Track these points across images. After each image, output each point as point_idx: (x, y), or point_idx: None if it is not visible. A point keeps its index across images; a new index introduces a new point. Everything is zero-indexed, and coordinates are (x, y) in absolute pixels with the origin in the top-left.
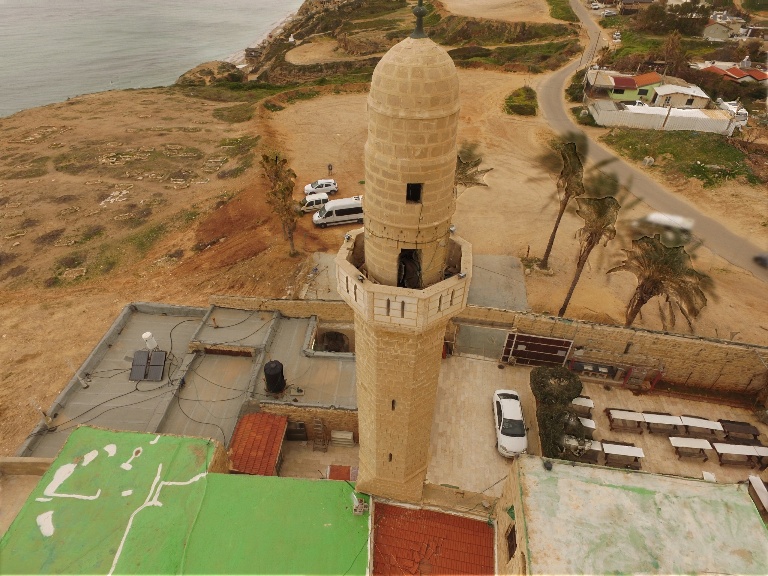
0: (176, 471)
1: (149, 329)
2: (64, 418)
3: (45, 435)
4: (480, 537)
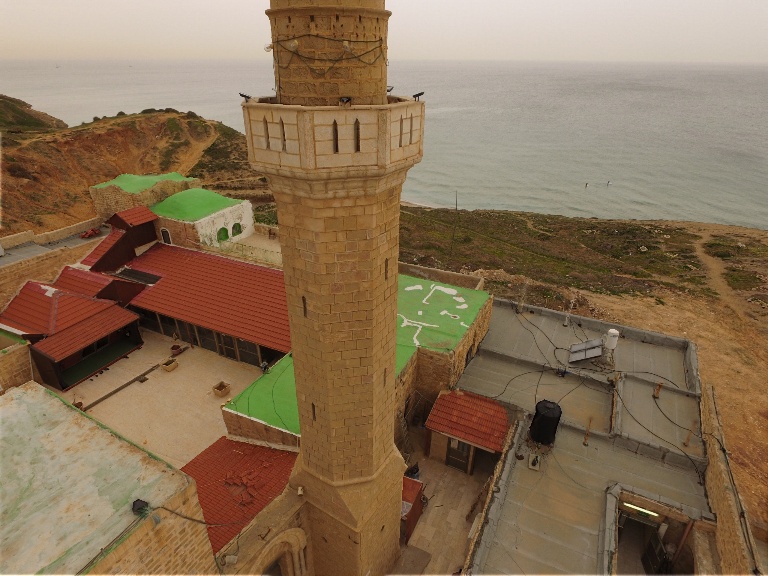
0: (429, 333)
1: (655, 360)
2: (529, 316)
3: (512, 308)
4: (214, 553)
